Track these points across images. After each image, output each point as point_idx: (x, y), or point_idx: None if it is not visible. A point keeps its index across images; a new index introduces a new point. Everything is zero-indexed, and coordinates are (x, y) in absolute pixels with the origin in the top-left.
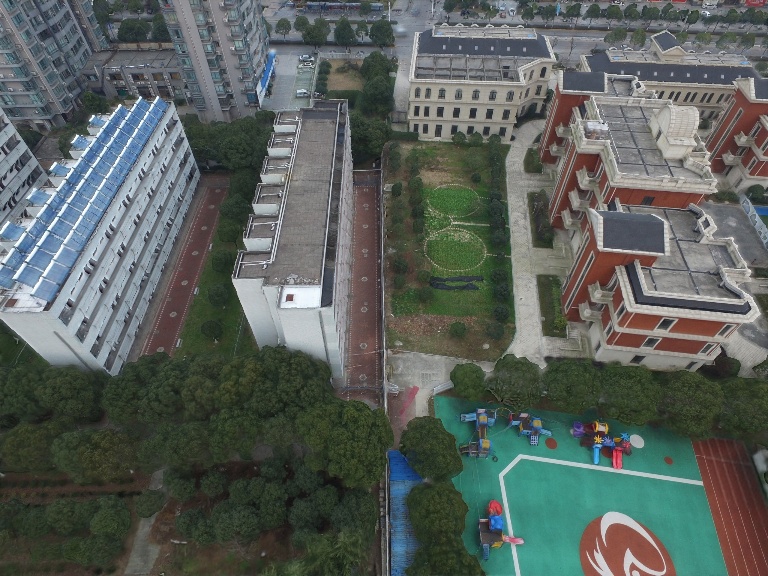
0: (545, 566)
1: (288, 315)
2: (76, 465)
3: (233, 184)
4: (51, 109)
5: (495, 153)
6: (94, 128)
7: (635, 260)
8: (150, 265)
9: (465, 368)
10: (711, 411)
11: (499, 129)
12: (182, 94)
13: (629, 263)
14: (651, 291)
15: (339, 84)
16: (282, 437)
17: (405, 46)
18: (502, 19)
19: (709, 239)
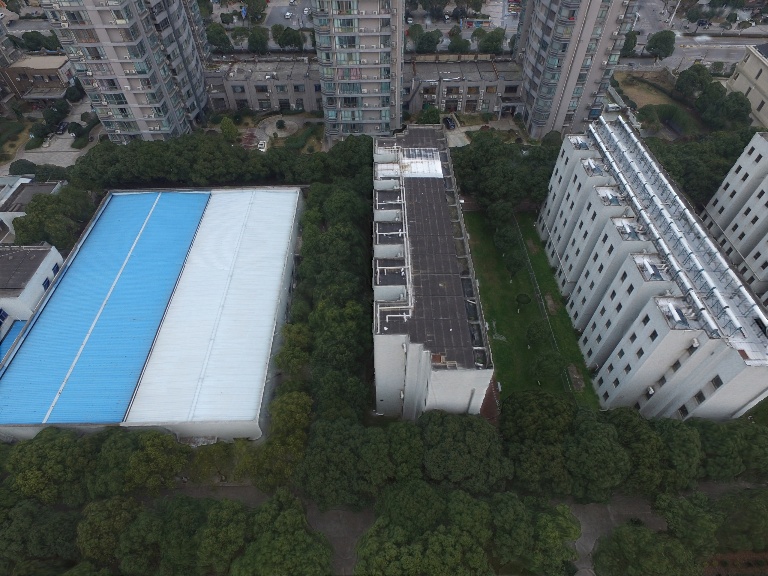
0: None
1: None
2: None
3: None
4: (390, 125)
5: None
6: (582, 150)
7: None
8: None
9: None
10: None
11: None
12: (488, 108)
13: None
14: None
15: (639, 98)
16: None
17: (669, 57)
18: (744, 29)
19: None
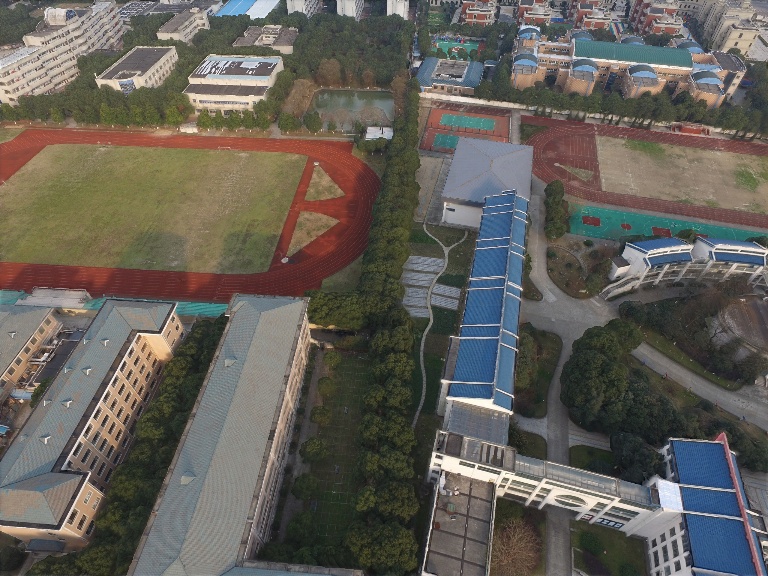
0: (443, 49)
1: (398, 4)
2: (358, 27)
3: (376, 3)
4: None
5: (452, 5)
6: None
7: (470, 5)
8: (358, 15)
9: (432, 26)
10: (479, 28)
11: (455, 2)
12: None
13: (469, 6)
14: (471, 8)
15: None
16: (397, 21)
17: None
18: None
19: (490, 5)
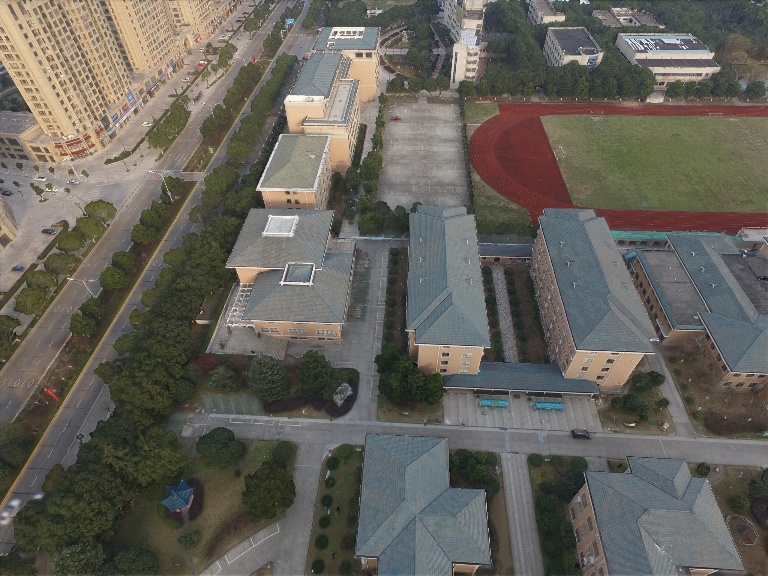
0: None
1: None
2: None
3: None
4: None
5: None
6: None
7: None
8: None
9: None
10: None
11: None
12: None
13: None
14: None
15: None
16: (734, 1)
17: None
18: None
19: None
